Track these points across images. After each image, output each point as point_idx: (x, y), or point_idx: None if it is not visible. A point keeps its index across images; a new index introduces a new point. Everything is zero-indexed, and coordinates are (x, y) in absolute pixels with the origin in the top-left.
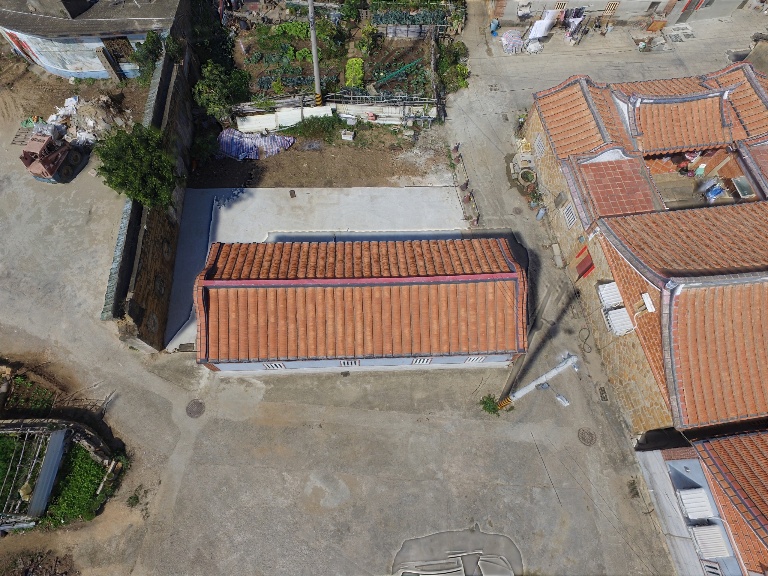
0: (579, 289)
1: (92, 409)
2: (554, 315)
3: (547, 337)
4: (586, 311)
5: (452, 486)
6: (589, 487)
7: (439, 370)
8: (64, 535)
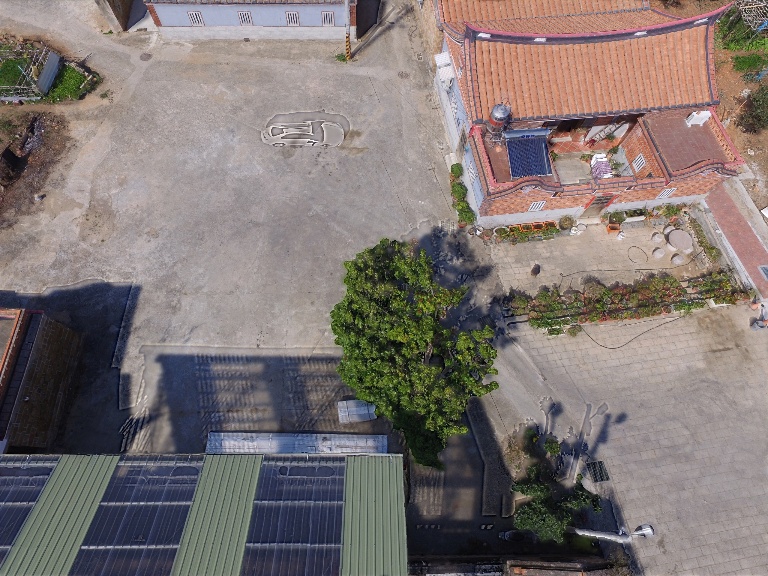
0: (413, 4)
1: (78, 61)
2: (395, 19)
3: (387, 29)
4: (416, 16)
5: (310, 93)
6: (400, 97)
7: (310, 41)
8: (59, 107)
